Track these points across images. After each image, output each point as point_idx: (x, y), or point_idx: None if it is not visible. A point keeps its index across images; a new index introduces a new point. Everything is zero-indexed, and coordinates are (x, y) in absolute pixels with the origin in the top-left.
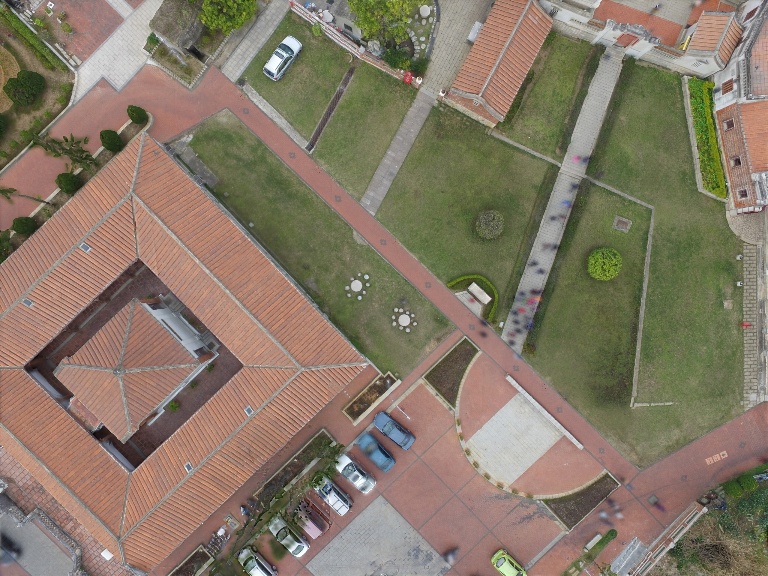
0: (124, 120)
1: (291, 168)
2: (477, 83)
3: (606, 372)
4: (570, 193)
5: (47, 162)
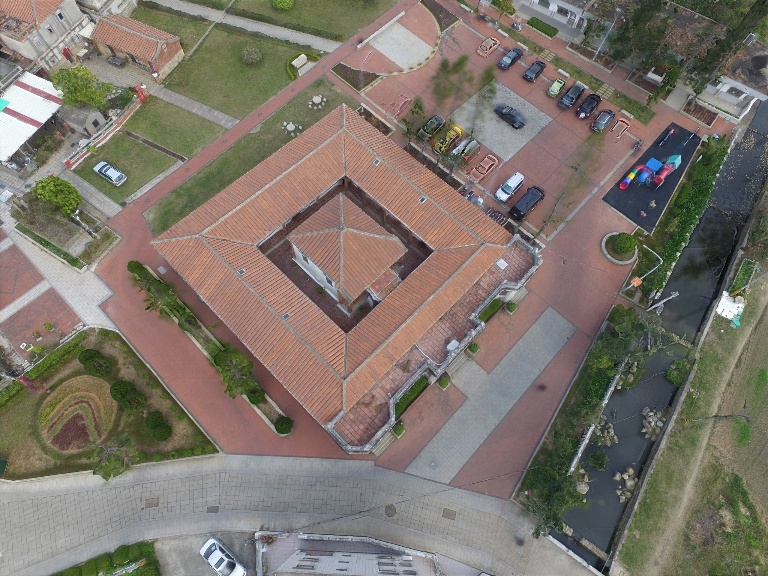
0: (139, 289)
1: (197, 171)
2: (151, 45)
3: (354, 3)
4: (235, 19)
5: (167, 353)
